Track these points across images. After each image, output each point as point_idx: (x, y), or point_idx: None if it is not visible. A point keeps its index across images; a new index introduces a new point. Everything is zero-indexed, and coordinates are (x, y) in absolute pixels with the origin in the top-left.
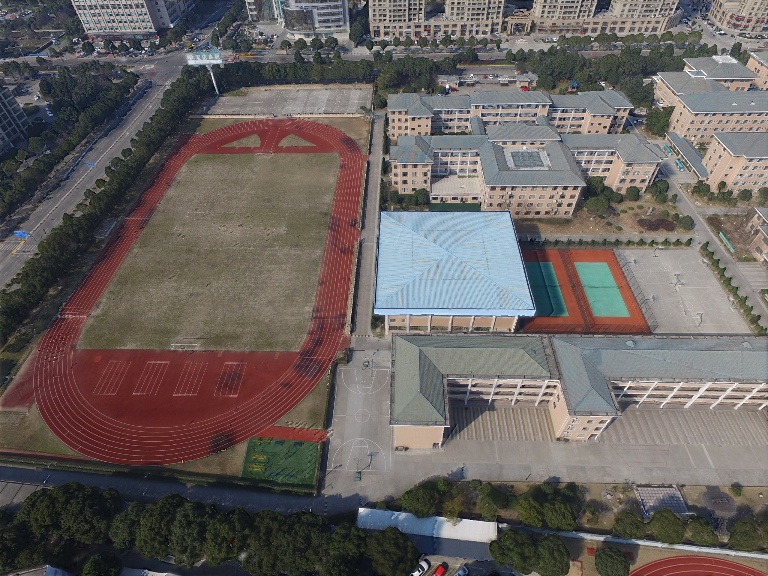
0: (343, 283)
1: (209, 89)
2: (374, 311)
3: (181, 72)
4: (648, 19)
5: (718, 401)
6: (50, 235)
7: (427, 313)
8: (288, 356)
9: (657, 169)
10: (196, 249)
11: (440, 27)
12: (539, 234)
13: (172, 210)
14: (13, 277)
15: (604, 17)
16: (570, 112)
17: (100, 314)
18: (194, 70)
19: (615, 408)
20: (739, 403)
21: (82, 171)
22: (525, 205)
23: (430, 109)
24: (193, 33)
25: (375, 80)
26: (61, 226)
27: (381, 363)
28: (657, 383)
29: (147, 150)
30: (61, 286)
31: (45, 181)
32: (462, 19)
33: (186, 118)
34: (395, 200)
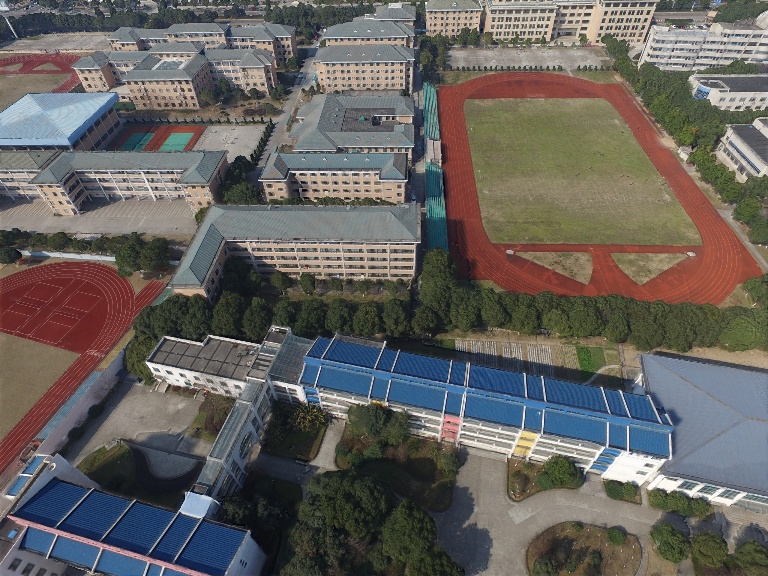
0: None
1: (8, 34)
2: None
3: None
4: None
5: (167, 193)
6: None
7: (1, 143)
8: None
9: (271, 75)
10: None
11: None
12: (166, 118)
13: None
14: None
15: None
16: (247, 41)
17: None
18: None
19: (59, 180)
20: (183, 195)
21: None
22: (160, 98)
23: (136, 38)
24: None
25: None
26: None
27: None
28: (111, 174)
29: None
30: None
31: None
32: None
33: None
34: None
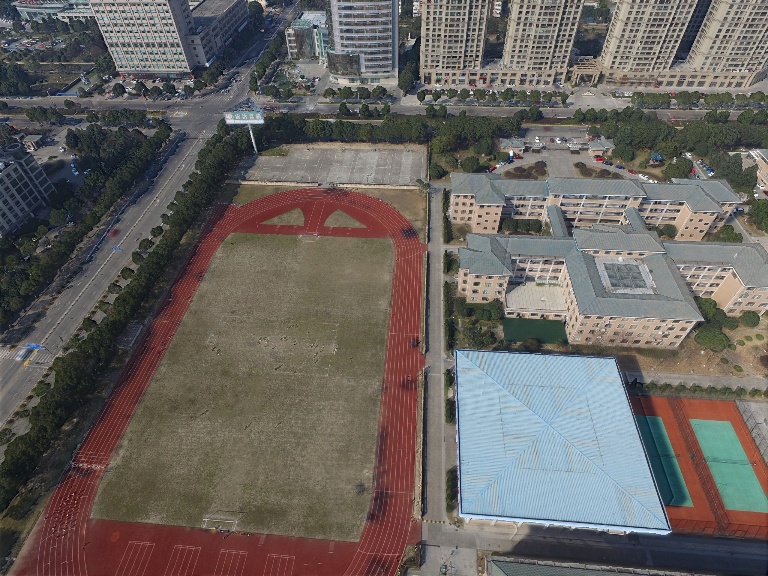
0: (408, 434)
1: (247, 147)
2: (460, 515)
3: (217, 127)
4: (733, 74)
5: None
6: (67, 356)
7: None
8: (345, 549)
9: None
10: (233, 371)
11: (497, 75)
12: (640, 372)
13: (206, 312)
14: (23, 402)
15: (682, 70)
16: (664, 204)
17: (120, 465)
18: (231, 124)
19: None
20: None
21: (107, 251)
22: (623, 334)
23: (501, 196)
24: (229, 72)
25: (429, 141)
26: (80, 329)
27: (462, 570)
28: None
29: (179, 231)
30: (77, 418)
31: (66, 263)
32: (522, 67)
33: (222, 183)
34: (464, 314)
